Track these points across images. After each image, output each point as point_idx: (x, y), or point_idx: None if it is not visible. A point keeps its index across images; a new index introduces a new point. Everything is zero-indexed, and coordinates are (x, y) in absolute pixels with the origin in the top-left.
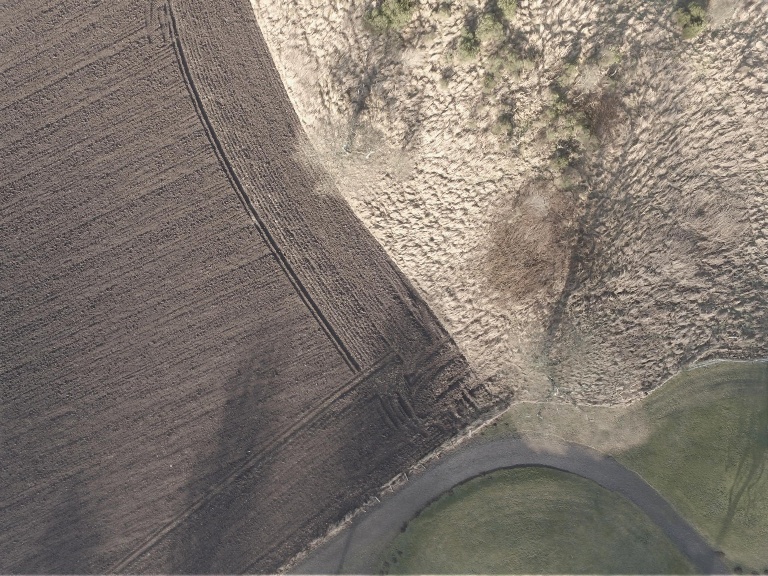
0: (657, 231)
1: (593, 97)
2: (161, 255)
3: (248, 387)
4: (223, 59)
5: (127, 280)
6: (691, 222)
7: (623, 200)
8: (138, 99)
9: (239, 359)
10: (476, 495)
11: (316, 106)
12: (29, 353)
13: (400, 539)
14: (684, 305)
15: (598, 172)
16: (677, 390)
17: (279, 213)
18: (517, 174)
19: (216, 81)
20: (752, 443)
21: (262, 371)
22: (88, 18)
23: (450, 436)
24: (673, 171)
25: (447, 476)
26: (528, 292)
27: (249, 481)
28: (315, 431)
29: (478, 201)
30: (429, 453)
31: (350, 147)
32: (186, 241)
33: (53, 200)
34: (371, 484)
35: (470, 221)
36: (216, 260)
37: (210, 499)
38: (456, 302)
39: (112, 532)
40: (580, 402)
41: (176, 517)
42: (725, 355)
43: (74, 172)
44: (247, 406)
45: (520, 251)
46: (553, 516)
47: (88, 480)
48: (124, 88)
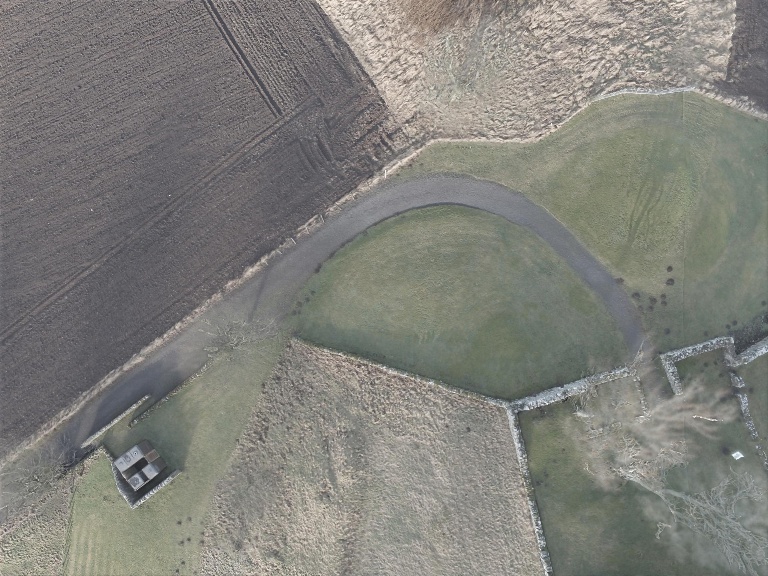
0: None
1: None
2: None
3: (171, 131)
4: None
5: (56, 25)
6: None
7: None
8: None
9: (163, 103)
10: (389, 233)
11: None
12: None
13: (313, 279)
14: (595, 40)
15: None
16: (585, 123)
17: None
18: None
19: None
20: (653, 168)
21: (185, 115)
22: None
23: (366, 178)
24: None
25: (362, 217)
26: (445, 24)
27: (168, 225)
28: (235, 174)
29: None
30: (345, 194)
31: None
32: None
33: None
34: (288, 227)
35: None
36: (144, 4)
37: (129, 243)
38: (376, 40)
39: (30, 275)
40: (492, 138)
41: (95, 261)
42: (633, 88)
43: None
44: (169, 150)
45: None
46: (461, 248)
47: (9, 223)
48: None
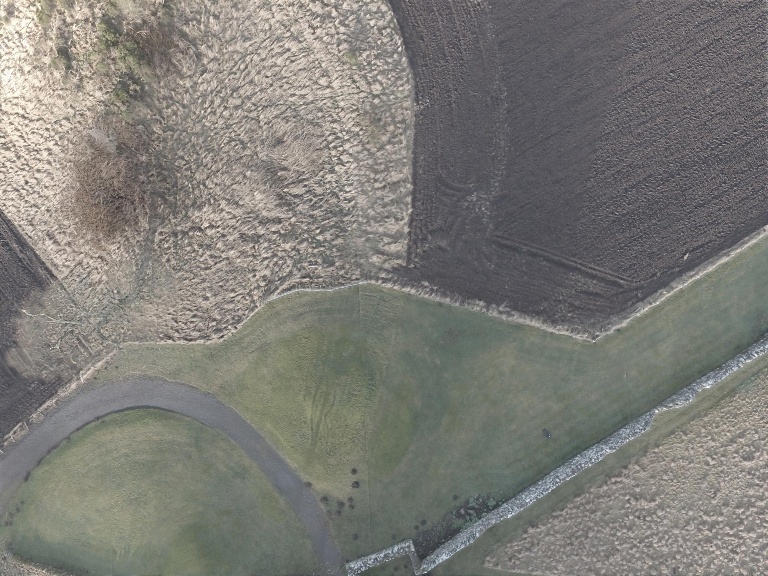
0: (237, 163)
1: (146, 26)
2: None
3: None
4: None
5: None
6: (268, 152)
7: (201, 132)
8: None
9: None
10: (88, 440)
11: None
12: None
13: (23, 489)
14: (267, 236)
15: (169, 104)
16: (264, 322)
17: None
18: (86, 110)
19: None
20: (326, 371)
21: None
22: None
23: (65, 382)
24: (248, 101)
25: (65, 423)
26: (115, 230)
27: None
28: None
29: (58, 140)
30: (46, 401)
31: None
32: None
33: None
34: None
35: (56, 161)
36: None
37: None
38: (56, 245)
39: None
40: (177, 340)
41: None
42: (307, 285)
43: None
44: None
45: (97, 188)
46: (155, 456)
47: None
48: None
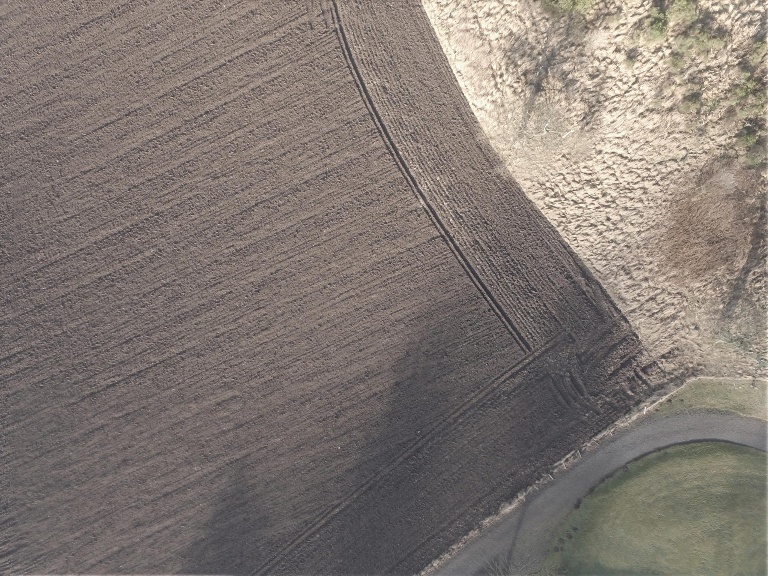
0: None
1: None
2: (326, 239)
3: (417, 368)
4: (388, 44)
5: (292, 264)
6: None
7: None
8: (300, 85)
9: (407, 341)
10: (653, 470)
11: (489, 89)
12: (192, 338)
13: (574, 515)
14: None
15: None
16: None
17: (448, 196)
18: (702, 152)
19: (381, 66)
20: None
21: (431, 352)
22: (247, 5)
23: (624, 413)
24: None
25: (621, 452)
26: (708, 269)
27: (418, 461)
28: (486, 411)
29: (659, 180)
30: (603, 430)
31: (524, 129)
32: (352, 225)
33: (214, 186)
34: (543, 462)
35: (649, 200)
36: (383, 243)
37: (379, 480)
38: (632, 280)
39: (280, 514)
40: (759, 377)
41: (345, 498)
42: None
43: (235, 158)
44: (416, 387)
45: (703, 228)
46: (734, 489)
47: (255, 463)
48: (286, 74)
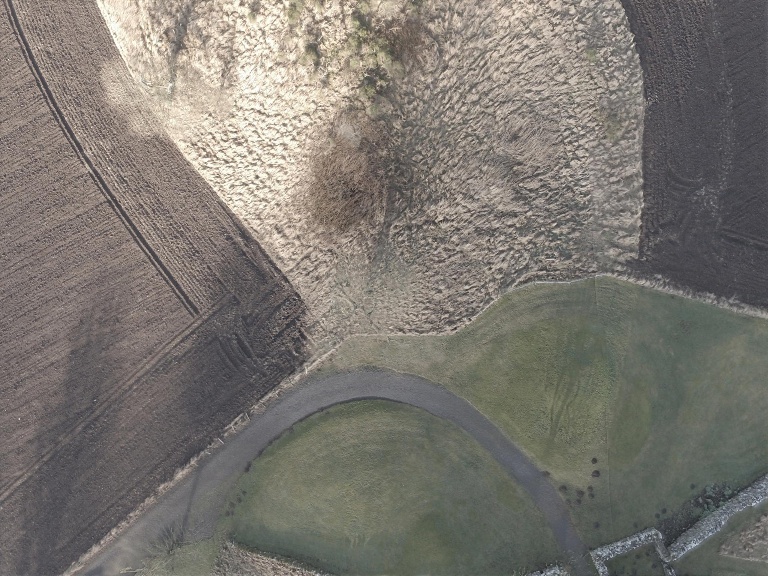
0: (473, 157)
1: (396, 23)
2: None
3: (91, 336)
4: (50, 8)
5: None
6: (505, 147)
7: (438, 128)
8: None
9: (81, 309)
10: (314, 430)
11: (139, 49)
12: None
13: (244, 479)
14: (503, 230)
15: (410, 100)
16: (499, 314)
17: (112, 160)
18: (329, 105)
19: (45, 31)
20: (569, 361)
21: (104, 319)
22: None
23: (288, 374)
24: (485, 97)
25: (287, 414)
26: (350, 224)
27: (96, 430)
28: (158, 376)
29: (296, 135)
30: (268, 392)
31: (173, 89)
32: (23, 193)
33: None
34: (214, 426)
35: (291, 156)
36: (53, 210)
37: (59, 450)
38: (284, 239)
39: None
40: (408, 332)
41: (26, 470)
42: (544, 277)
43: None
44: (91, 355)
45: (337, 182)
46: (386, 446)
47: None
48: None
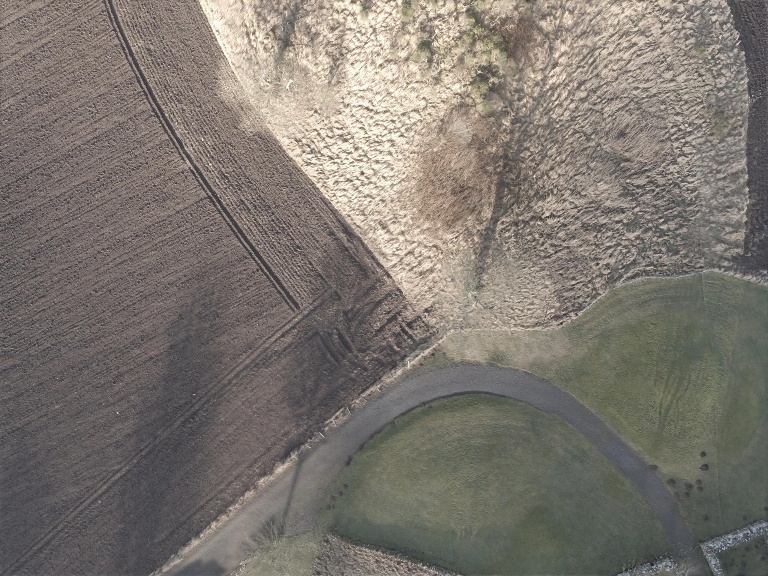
0: (581, 154)
1: (510, 21)
2: (99, 204)
3: (190, 331)
4: (151, 6)
5: (66, 231)
6: (613, 143)
7: (546, 124)
8: (69, 50)
9: (180, 304)
10: (417, 424)
11: (243, 46)
12: None
13: (345, 472)
14: (610, 226)
15: (520, 97)
16: (606, 310)
17: (213, 156)
18: (440, 102)
19: (145, 28)
20: (679, 356)
21: (203, 314)
22: None
23: (390, 368)
24: (594, 94)
25: (388, 408)
26: (457, 220)
27: (195, 424)
28: (258, 371)
29: (404, 132)
30: (370, 386)
31: (278, 86)
32: (123, 189)
33: None
34: (315, 420)
35: (398, 152)
36: (153, 206)
37: (158, 444)
38: (389, 235)
39: (62, 481)
40: (513, 327)
41: (125, 463)
42: (651, 273)
43: (9, 126)
44: (190, 350)
45: (447, 179)
46: (491, 440)
47: (36, 431)
48: (55, 40)
